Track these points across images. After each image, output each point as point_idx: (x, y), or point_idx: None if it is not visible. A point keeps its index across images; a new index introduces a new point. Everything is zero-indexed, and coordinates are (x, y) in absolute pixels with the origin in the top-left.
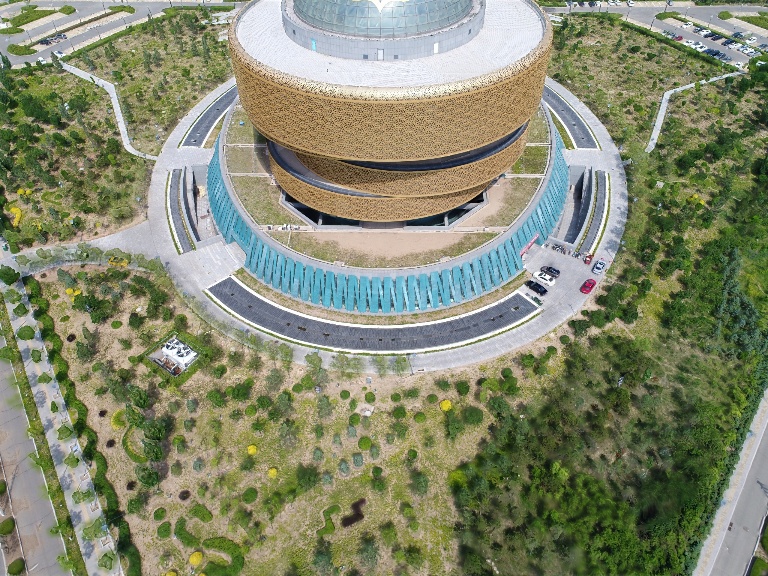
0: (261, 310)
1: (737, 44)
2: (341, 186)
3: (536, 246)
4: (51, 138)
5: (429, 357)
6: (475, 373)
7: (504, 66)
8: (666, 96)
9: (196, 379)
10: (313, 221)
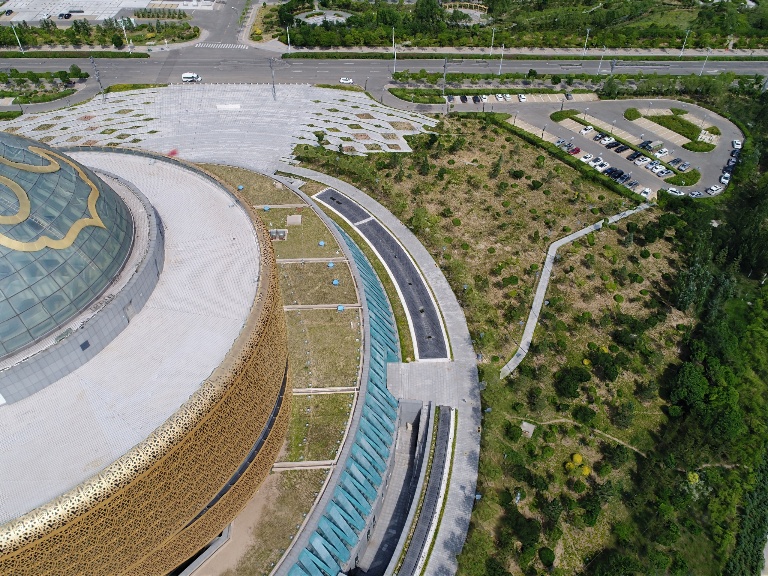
0: None
1: (645, 159)
2: None
3: None
4: None
5: None
6: None
7: (118, 449)
8: (551, 251)
9: None
10: None
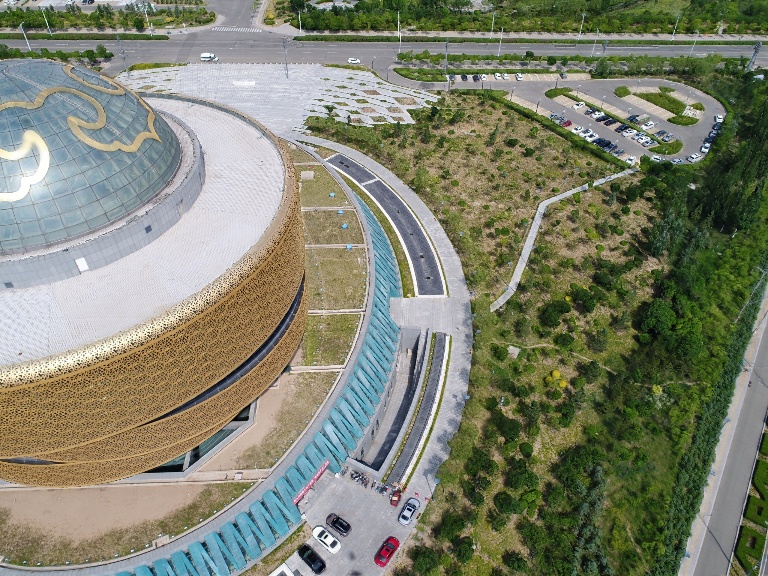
0: None
1: (631, 131)
2: None
3: (329, 474)
4: None
5: None
6: None
7: (179, 299)
8: (541, 209)
9: None
10: None
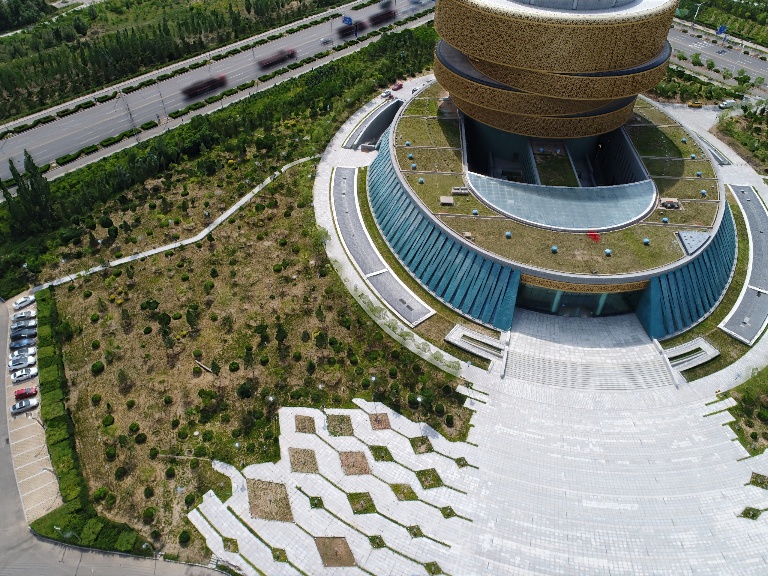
0: None
1: None
2: None
3: None
4: None
5: None
6: None
7: None
8: (205, 233)
9: None
10: None
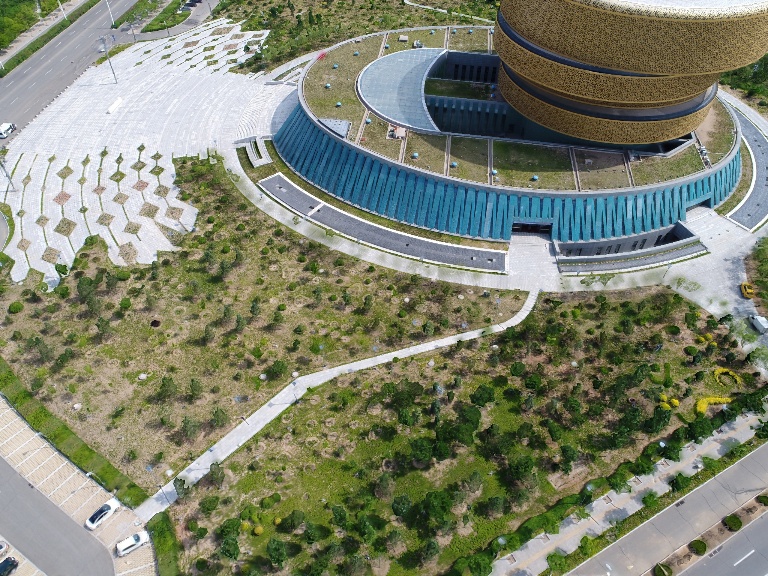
0: (759, 199)
1: None
2: (709, 87)
3: None
4: None
5: (764, 129)
6: (767, 114)
7: None
8: (414, 4)
9: None
10: (689, 140)
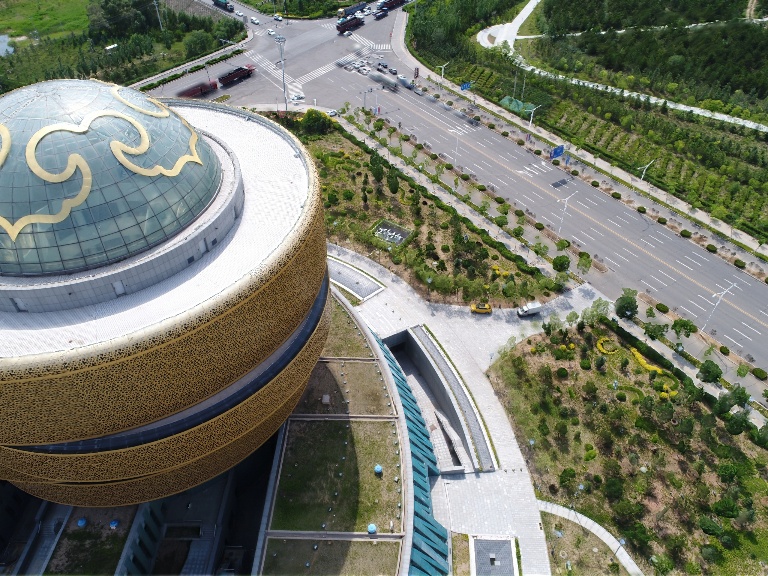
0: None
1: None
2: None
3: None
4: (764, 544)
5: None
6: None
7: None
8: None
9: (370, 223)
10: None
